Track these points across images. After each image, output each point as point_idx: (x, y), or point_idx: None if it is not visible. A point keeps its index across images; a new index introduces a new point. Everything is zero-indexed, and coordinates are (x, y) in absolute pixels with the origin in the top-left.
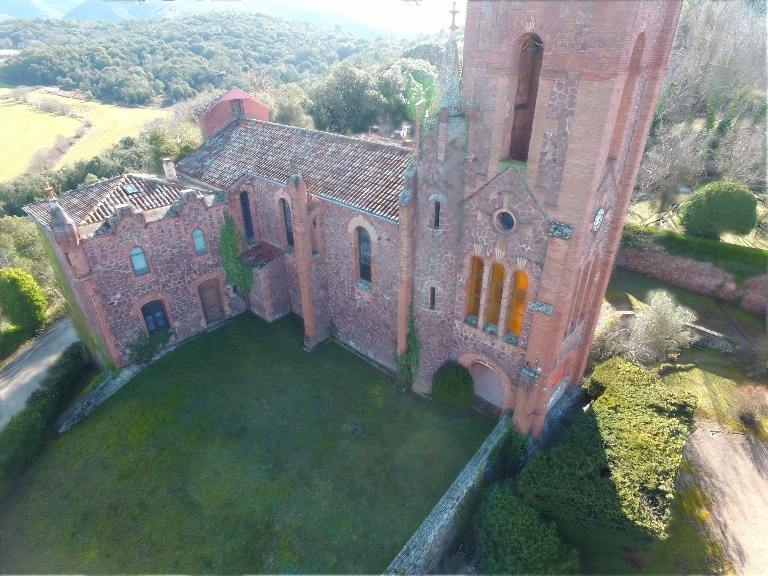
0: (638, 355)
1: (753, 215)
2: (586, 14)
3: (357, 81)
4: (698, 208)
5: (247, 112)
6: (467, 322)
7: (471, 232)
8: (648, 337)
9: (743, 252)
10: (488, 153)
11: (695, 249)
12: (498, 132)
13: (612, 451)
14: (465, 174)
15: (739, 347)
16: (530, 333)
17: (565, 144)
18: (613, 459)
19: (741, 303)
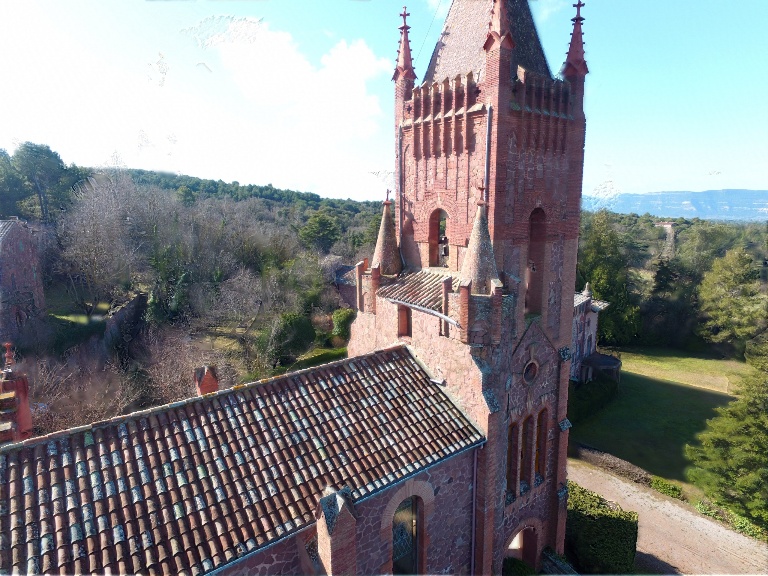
0: None
1: None
2: (564, 195)
3: None
4: None
5: None
6: (507, 503)
7: None
8: None
9: (324, 359)
10: None
11: None
12: (523, 294)
13: (569, 506)
14: None
15: None
16: (559, 456)
17: (560, 288)
18: (577, 509)
19: None
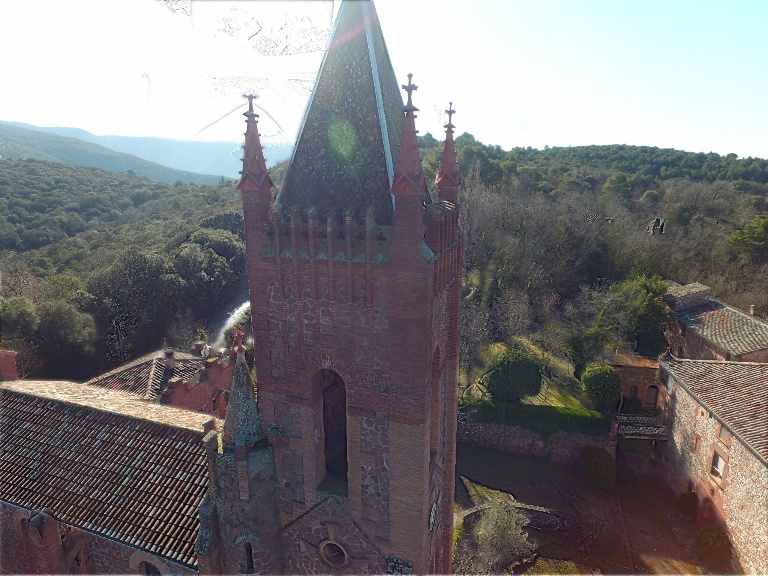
0: None
1: (539, 379)
2: (383, 362)
3: (149, 265)
4: (497, 377)
5: None
6: None
7: (296, 563)
8: (494, 549)
9: (541, 412)
10: (302, 480)
11: (504, 414)
12: (310, 460)
13: None
14: (278, 501)
15: (566, 522)
16: None
17: (386, 479)
18: None
19: (551, 458)
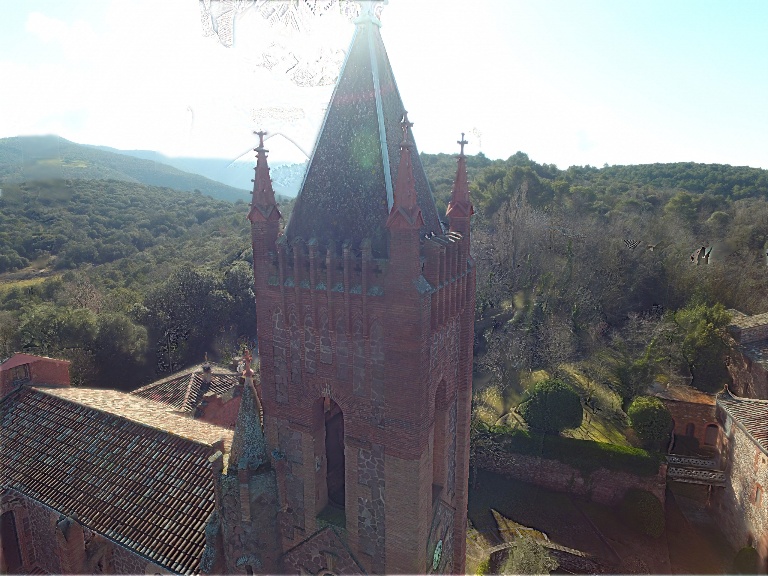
0: None
1: (580, 411)
2: (379, 393)
3: (200, 281)
4: (535, 407)
5: (36, 376)
6: None
7: None
8: None
9: (581, 447)
10: (303, 506)
11: (541, 447)
12: (310, 487)
13: None
14: (280, 525)
15: (603, 570)
16: None
17: (382, 513)
18: None
19: (592, 497)
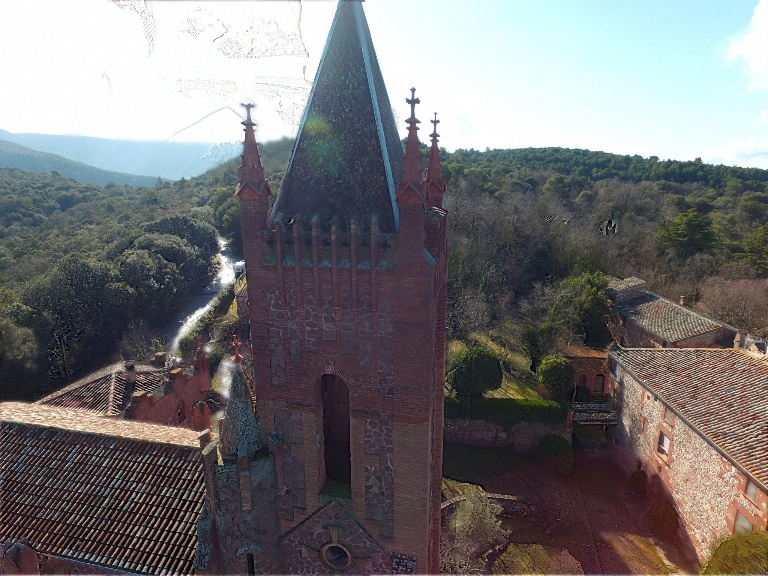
0: (470, 569)
1: (500, 373)
2: (387, 364)
3: (93, 274)
4: (461, 374)
5: None
6: None
7: (297, 569)
8: (470, 539)
9: (503, 405)
10: (303, 486)
11: (469, 409)
12: (312, 465)
13: None
14: (278, 509)
15: (533, 508)
16: None
17: (390, 478)
18: None
19: (514, 448)
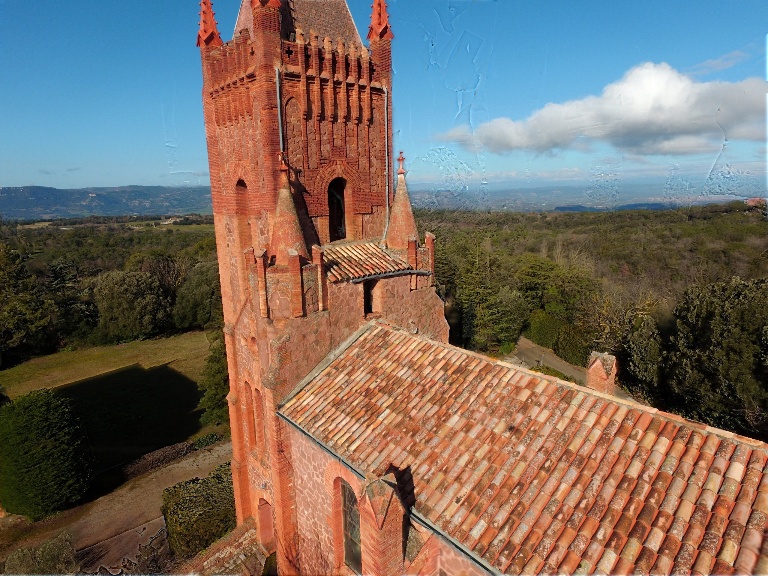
0: None
1: None
2: None
3: None
4: None
5: None
6: None
7: None
8: None
9: None
10: None
11: None
12: None
13: None
14: None
15: None
16: None
17: None
18: None
19: None
